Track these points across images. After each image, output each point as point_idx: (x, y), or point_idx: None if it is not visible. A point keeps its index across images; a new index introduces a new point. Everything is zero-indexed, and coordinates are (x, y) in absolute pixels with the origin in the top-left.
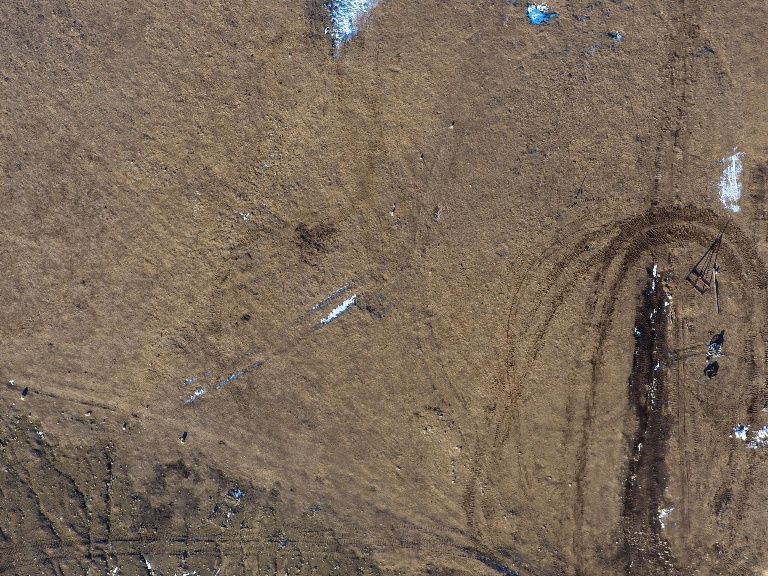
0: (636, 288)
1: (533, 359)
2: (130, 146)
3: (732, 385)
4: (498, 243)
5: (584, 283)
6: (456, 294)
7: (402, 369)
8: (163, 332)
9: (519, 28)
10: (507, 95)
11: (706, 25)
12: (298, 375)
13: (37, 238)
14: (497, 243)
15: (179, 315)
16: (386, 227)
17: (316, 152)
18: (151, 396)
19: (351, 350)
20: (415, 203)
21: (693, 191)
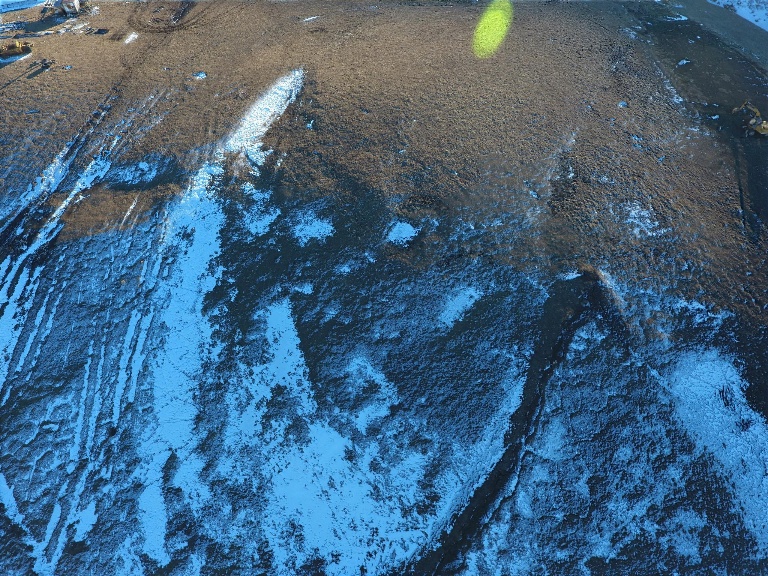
0: None
1: None
2: None
3: (155, 5)
4: None
5: None
6: None
7: None
8: None
9: None
10: None
11: None
12: (331, 8)
13: None
14: None
15: None
16: None
17: None
18: (394, 7)
19: None
20: None
21: None
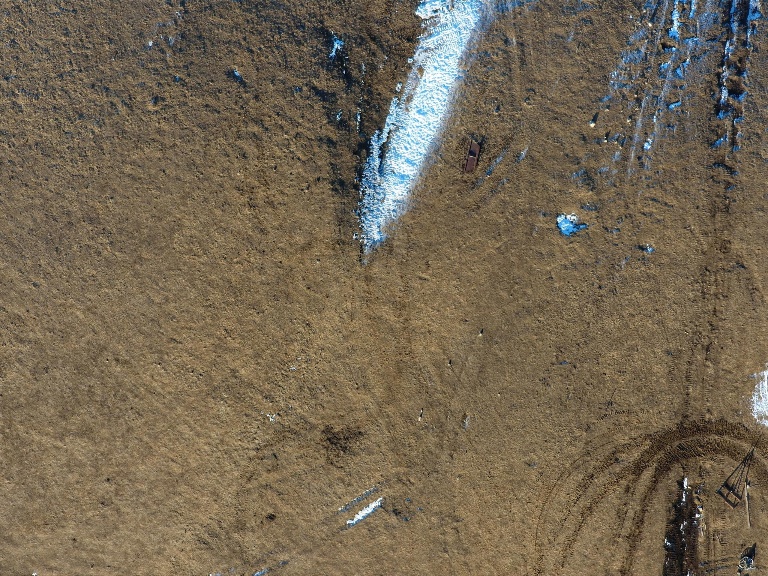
0: (666, 500)
1: (561, 567)
2: (157, 349)
3: None
4: (527, 453)
5: (614, 495)
6: (484, 501)
7: (428, 572)
8: (187, 528)
9: (548, 238)
10: (536, 305)
11: (737, 241)
12: (323, 575)
13: (63, 438)
14: (526, 453)
15: (204, 512)
16: (413, 431)
17: (343, 356)
18: None
19: (377, 552)
20: (443, 409)
21: (724, 405)
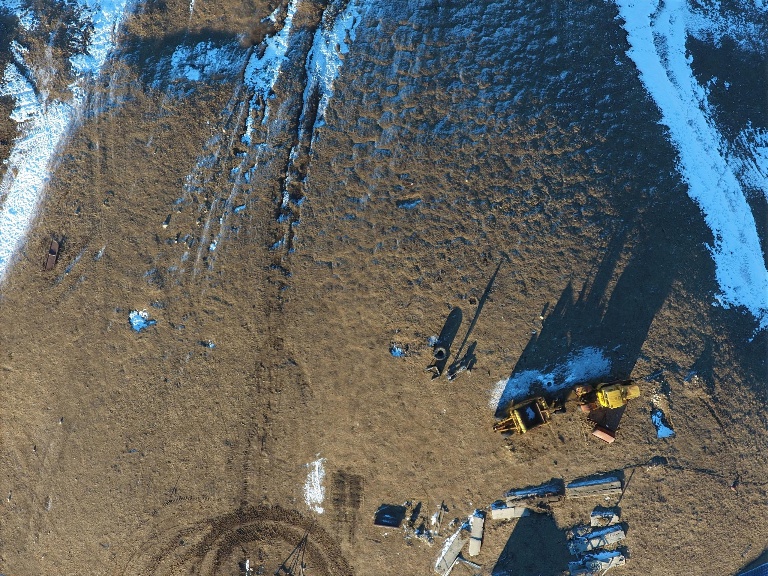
0: None
1: None
2: None
3: None
4: (101, 535)
5: (180, 575)
6: None
7: None
8: None
9: (121, 333)
10: (109, 396)
11: (289, 339)
12: None
13: None
14: (100, 535)
15: None
16: (3, 512)
17: None
18: None
19: None
20: (29, 491)
21: (280, 493)
